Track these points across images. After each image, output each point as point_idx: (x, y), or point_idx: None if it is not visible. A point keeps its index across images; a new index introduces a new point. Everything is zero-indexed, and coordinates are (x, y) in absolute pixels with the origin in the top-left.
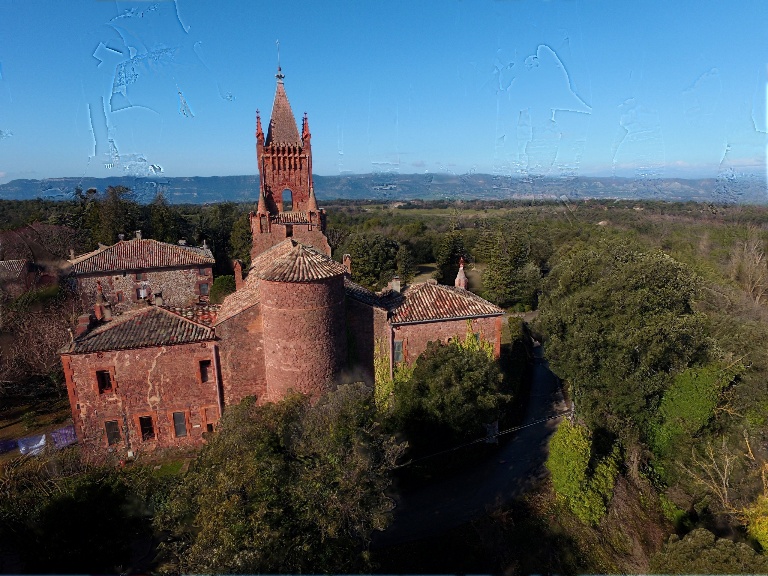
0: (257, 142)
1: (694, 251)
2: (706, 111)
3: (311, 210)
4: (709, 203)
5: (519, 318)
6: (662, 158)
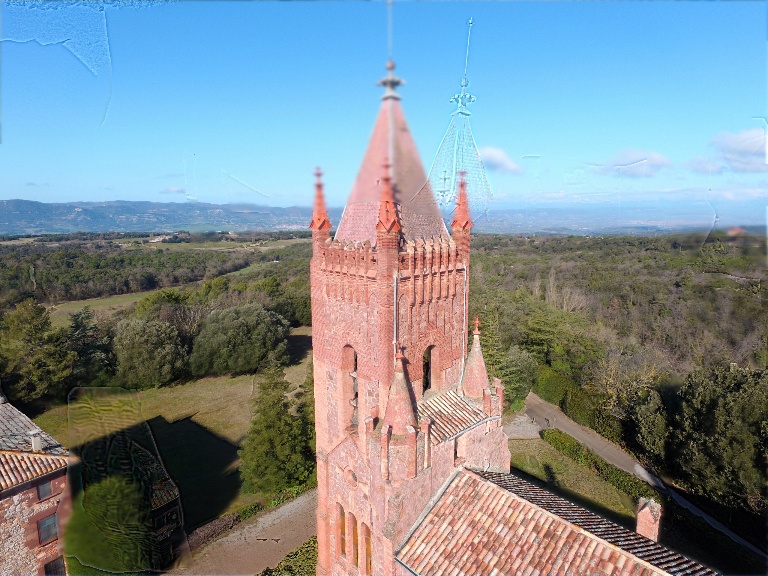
0: (387, 242)
1: (721, 330)
2: (637, 175)
3: (482, 385)
4: (754, 283)
5: (564, 434)
6: (618, 222)
